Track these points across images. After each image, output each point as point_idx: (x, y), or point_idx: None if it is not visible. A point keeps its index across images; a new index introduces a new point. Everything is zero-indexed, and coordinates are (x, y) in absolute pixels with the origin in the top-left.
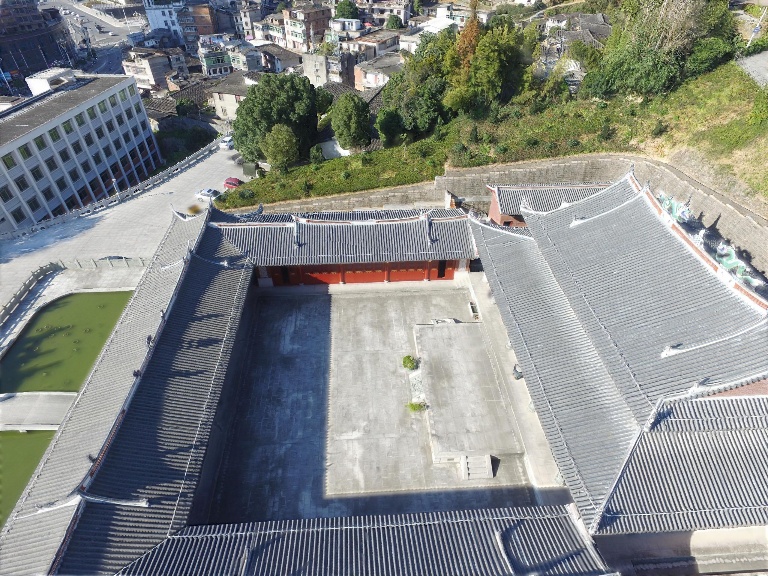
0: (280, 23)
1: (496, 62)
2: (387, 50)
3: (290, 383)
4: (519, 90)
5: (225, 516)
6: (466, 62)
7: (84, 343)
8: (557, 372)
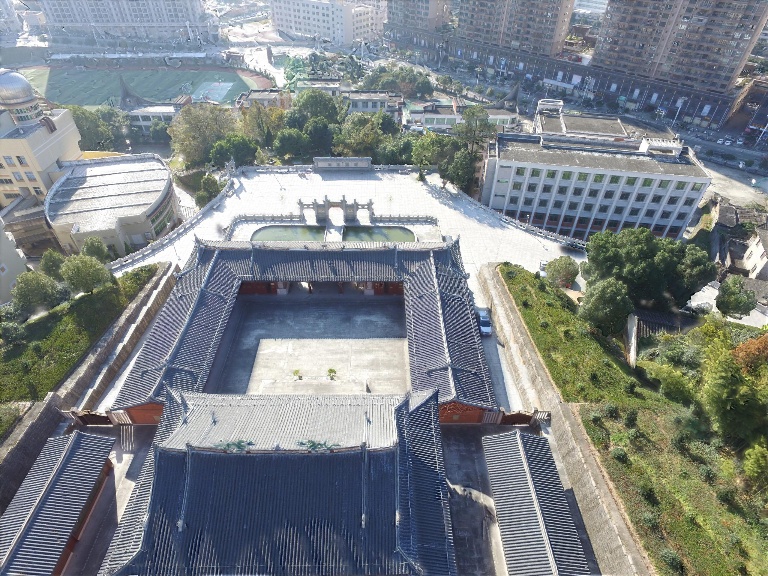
0: None
1: (713, 389)
2: None
3: (331, 322)
4: (745, 462)
5: (262, 306)
6: None
7: None
8: None
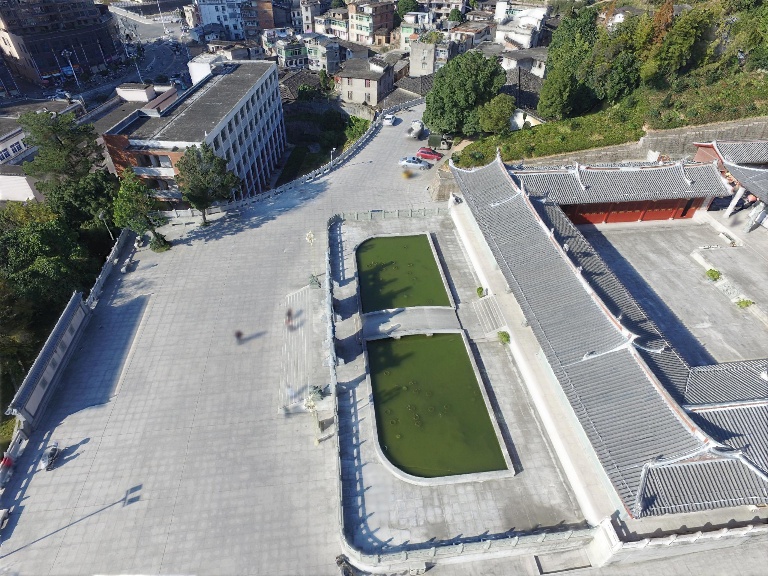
0: (343, 17)
1: (693, 38)
2: (481, 39)
3: None
4: (698, 63)
5: None
6: (660, 39)
7: (417, 274)
8: None
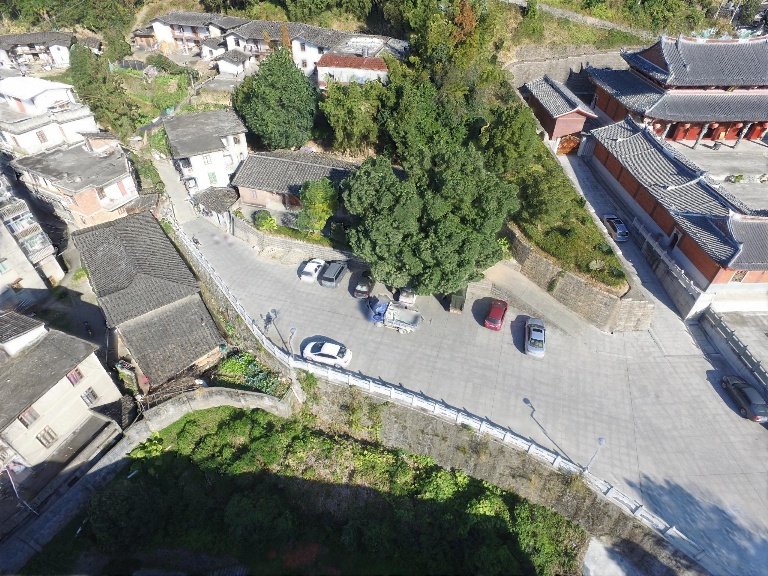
0: None
1: None
2: None
3: None
4: None
5: None
6: None
7: None
8: (765, 109)
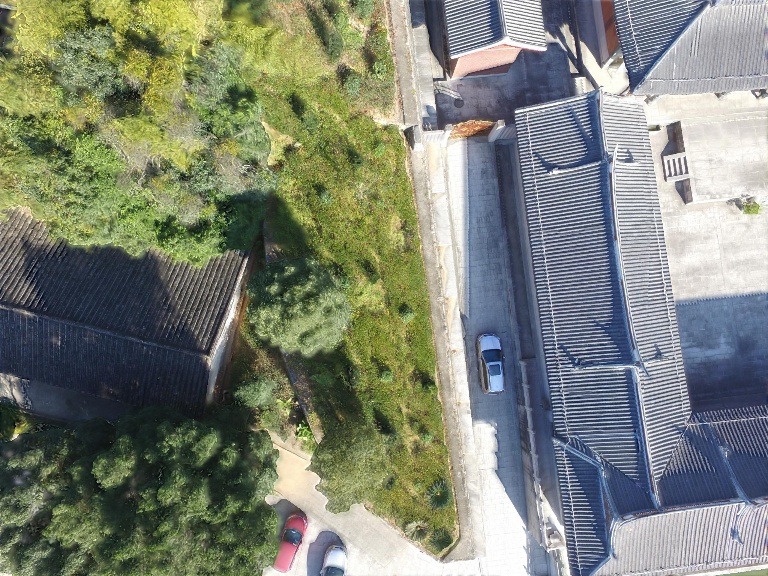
0: None
1: None
2: None
3: None
4: None
5: None
6: None
7: None
8: None
